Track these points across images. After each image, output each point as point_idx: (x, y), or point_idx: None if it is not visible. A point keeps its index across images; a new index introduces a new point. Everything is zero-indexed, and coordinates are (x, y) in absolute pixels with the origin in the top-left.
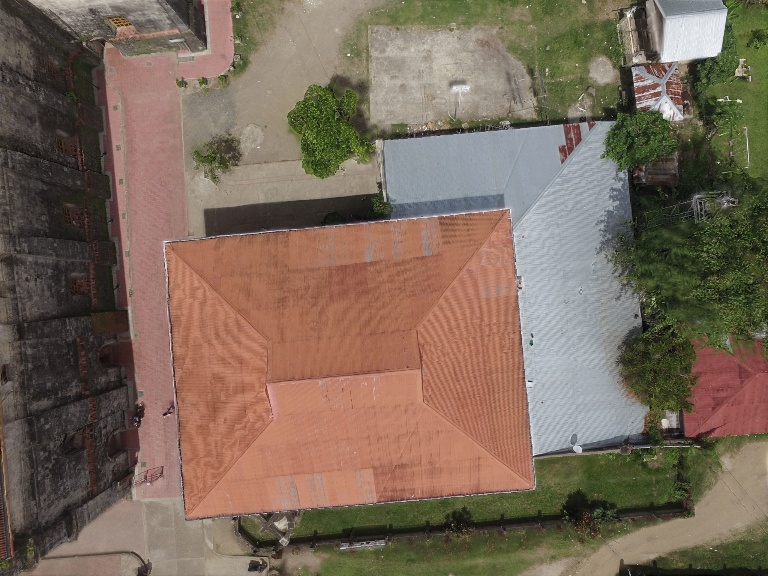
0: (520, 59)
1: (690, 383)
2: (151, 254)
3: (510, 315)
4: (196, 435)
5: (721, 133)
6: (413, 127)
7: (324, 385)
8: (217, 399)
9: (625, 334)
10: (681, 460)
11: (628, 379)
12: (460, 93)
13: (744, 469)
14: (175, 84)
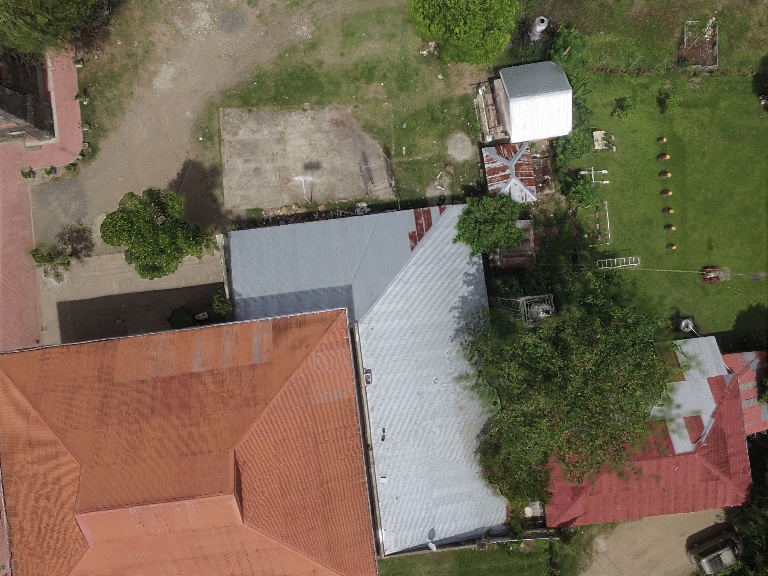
0: (376, 138)
1: (544, 475)
2: (3, 350)
3: (348, 418)
4: (24, 556)
5: (587, 205)
6: (269, 211)
7: (135, 513)
8: (41, 520)
9: (483, 422)
10: (551, 545)
11: (487, 469)
12: (303, 183)
13: (619, 549)
14: None
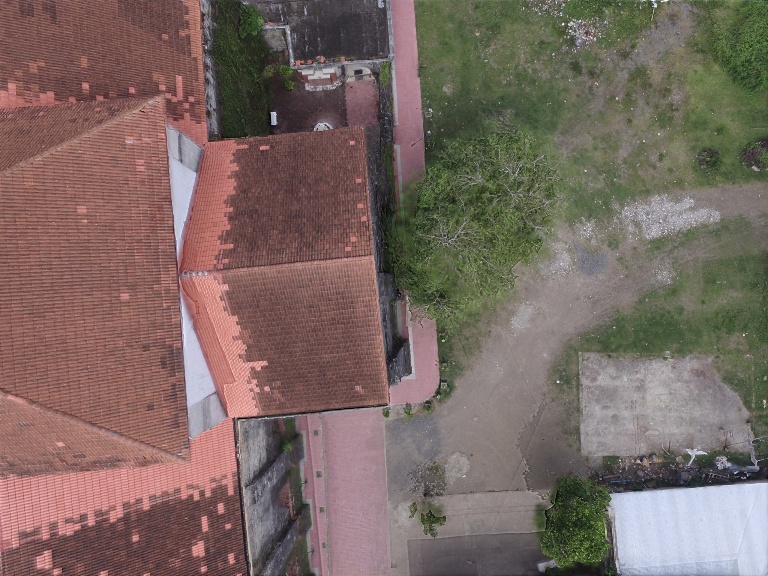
0: (737, 390)
1: None
2: None
3: None
4: None
5: None
6: (625, 459)
7: None
8: None
9: None
10: None
11: None
12: (694, 456)
13: None
14: (378, 409)
